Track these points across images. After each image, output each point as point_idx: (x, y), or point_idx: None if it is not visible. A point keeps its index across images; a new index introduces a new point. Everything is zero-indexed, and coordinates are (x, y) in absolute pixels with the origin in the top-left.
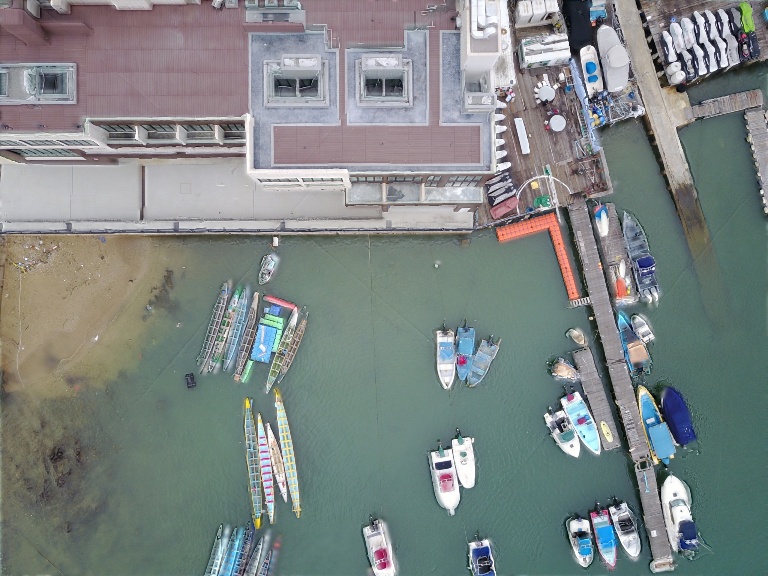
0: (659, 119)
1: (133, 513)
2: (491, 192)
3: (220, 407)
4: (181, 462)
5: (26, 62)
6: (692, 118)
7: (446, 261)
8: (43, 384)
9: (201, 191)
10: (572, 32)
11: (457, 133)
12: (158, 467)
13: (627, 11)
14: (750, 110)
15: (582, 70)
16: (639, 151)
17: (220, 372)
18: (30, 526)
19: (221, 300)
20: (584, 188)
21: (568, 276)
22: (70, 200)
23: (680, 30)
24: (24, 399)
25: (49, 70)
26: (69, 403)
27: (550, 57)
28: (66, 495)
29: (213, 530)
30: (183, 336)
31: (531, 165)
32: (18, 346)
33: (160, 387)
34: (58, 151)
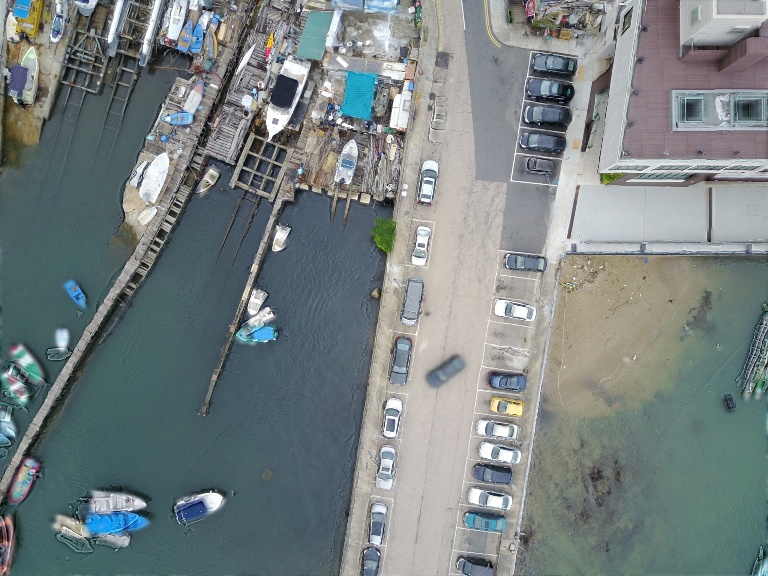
0: None
1: (669, 533)
2: None
3: (757, 428)
4: (716, 482)
5: (721, 88)
6: None
7: None
8: (582, 403)
9: (767, 213)
10: None
11: None
12: (694, 487)
13: None
14: None
15: None
16: None
17: (760, 393)
18: (568, 544)
19: (763, 321)
20: None
21: None
22: (643, 221)
23: None
24: (563, 418)
25: (745, 96)
26: (607, 422)
27: None
28: (605, 514)
29: (754, 551)
30: (719, 356)
31: None
32: (560, 365)
33: (695, 407)
34: (677, 174)
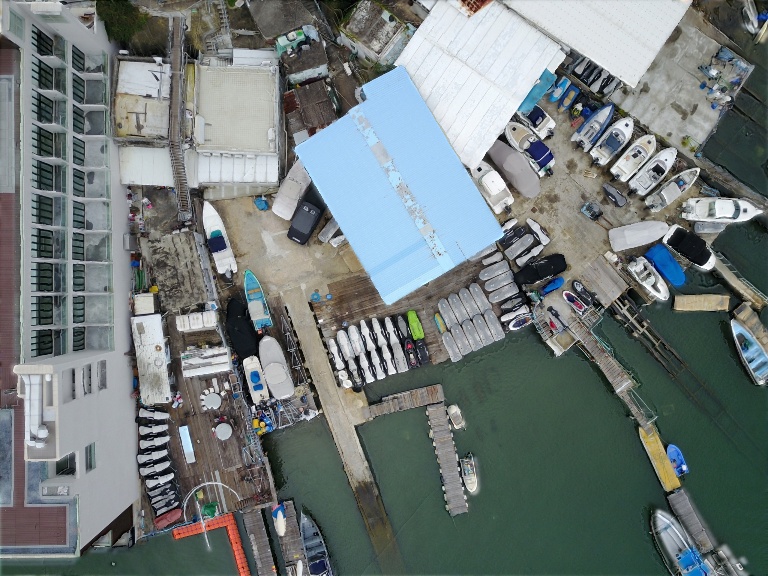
0: (337, 418)
1: None
2: (155, 502)
3: None
4: None
5: None
6: (369, 417)
7: (123, 559)
8: None
9: None
10: (234, 343)
11: (42, 514)
12: None
13: (300, 313)
14: (432, 406)
15: (246, 380)
16: (322, 445)
17: None
18: None
19: None
20: (253, 495)
21: (246, 575)
22: None
23: (344, 340)
24: None
25: None
26: None
27: (209, 371)
28: None
29: None
30: None
31: (200, 471)
32: None
33: None
34: None
